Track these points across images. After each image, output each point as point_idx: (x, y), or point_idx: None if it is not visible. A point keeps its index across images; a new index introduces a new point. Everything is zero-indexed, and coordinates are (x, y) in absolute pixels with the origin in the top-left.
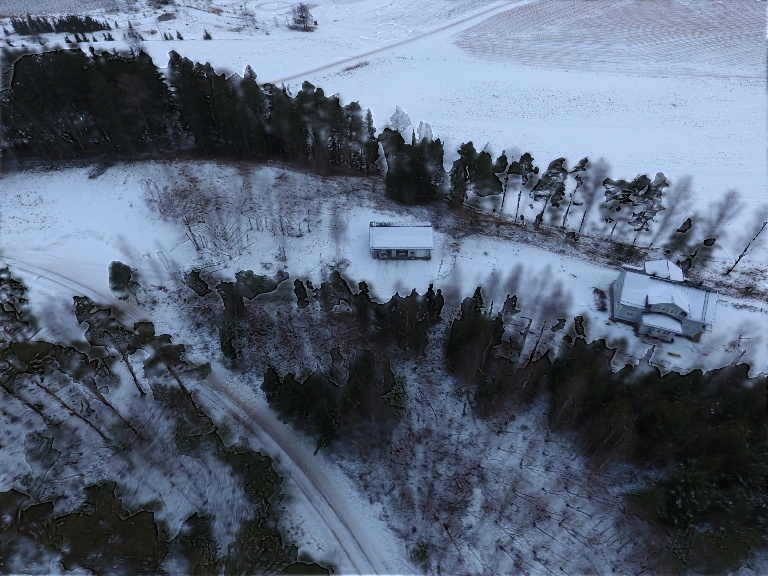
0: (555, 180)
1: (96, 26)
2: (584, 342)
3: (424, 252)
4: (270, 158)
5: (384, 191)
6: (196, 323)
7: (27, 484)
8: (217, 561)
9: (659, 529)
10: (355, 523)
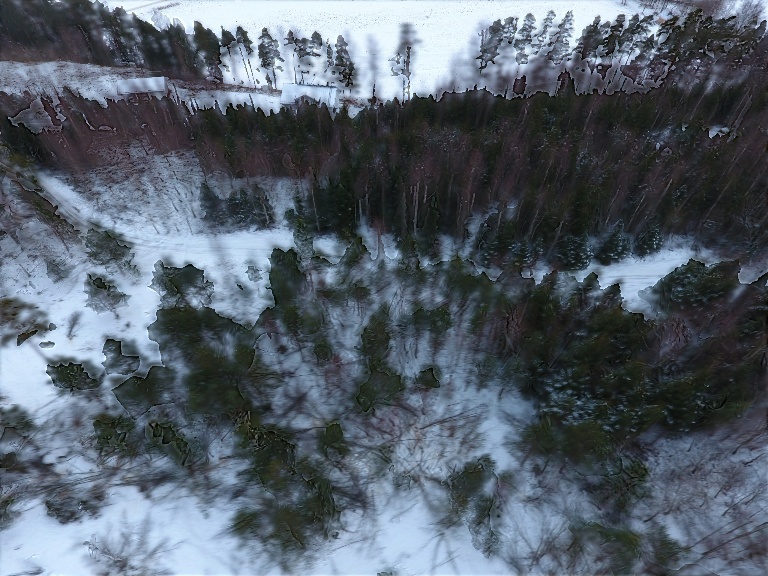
0: (272, 49)
1: None
2: None
3: (161, 95)
4: (60, 58)
5: (152, 73)
6: None
7: None
8: None
9: None
10: (54, 191)
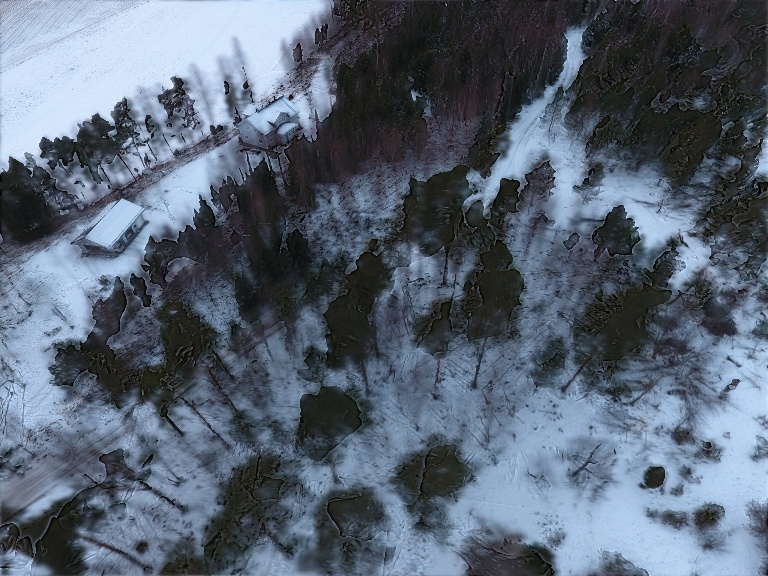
0: (125, 127)
1: None
2: None
3: (140, 219)
4: None
5: (12, 246)
6: (102, 405)
7: None
8: (385, 269)
9: (400, 158)
10: None
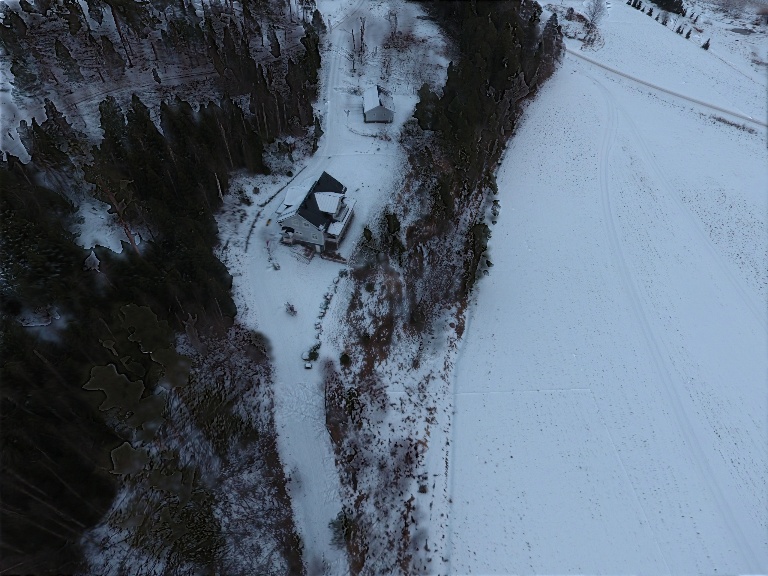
0: None
1: (679, 10)
2: (253, 134)
3: None
4: None
5: None
6: None
7: (205, 7)
8: (156, 18)
9: None
10: None
